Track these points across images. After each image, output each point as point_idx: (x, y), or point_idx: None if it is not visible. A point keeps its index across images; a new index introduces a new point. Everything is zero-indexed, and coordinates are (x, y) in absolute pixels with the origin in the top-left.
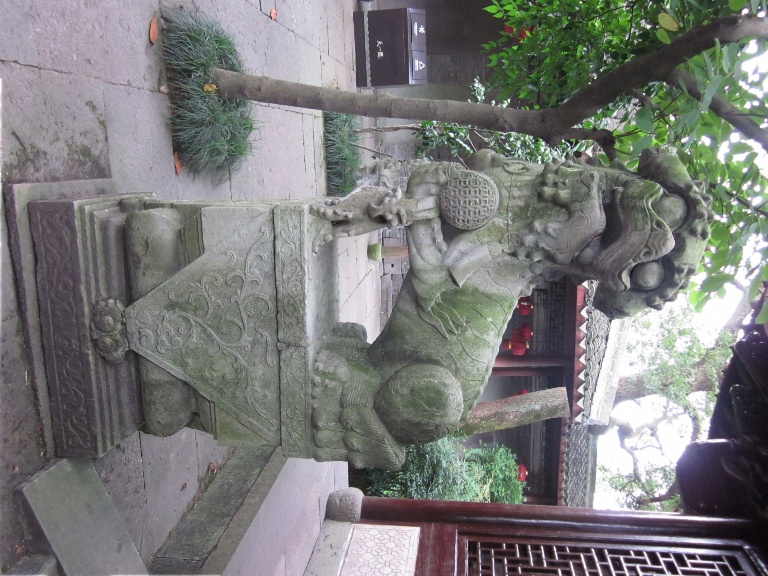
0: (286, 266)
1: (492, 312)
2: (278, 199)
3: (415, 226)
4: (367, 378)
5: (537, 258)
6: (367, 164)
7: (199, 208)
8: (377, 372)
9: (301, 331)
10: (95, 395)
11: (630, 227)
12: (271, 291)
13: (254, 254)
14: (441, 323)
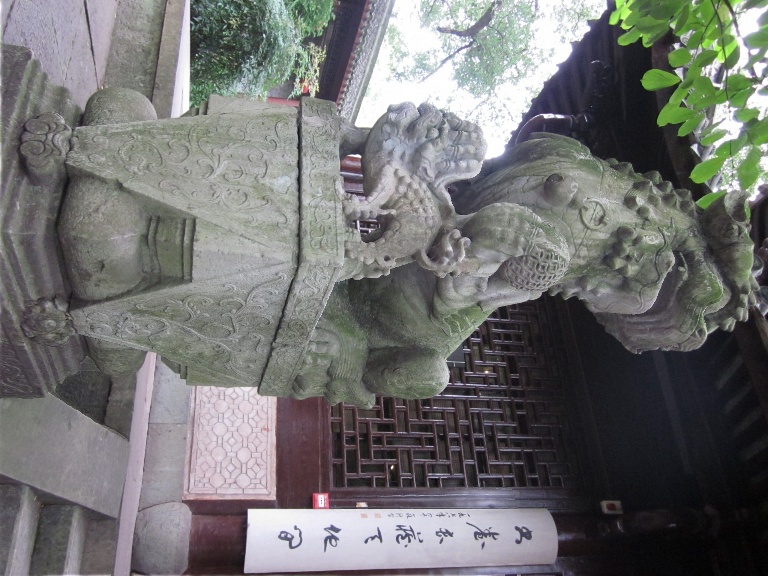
0: (302, 302)
1: None
2: (256, 118)
3: None
4: (355, 345)
5: None
6: (402, 122)
7: (173, 211)
8: (364, 333)
9: (304, 339)
10: (35, 366)
11: (674, 321)
12: (276, 313)
13: (262, 290)
14: (450, 328)
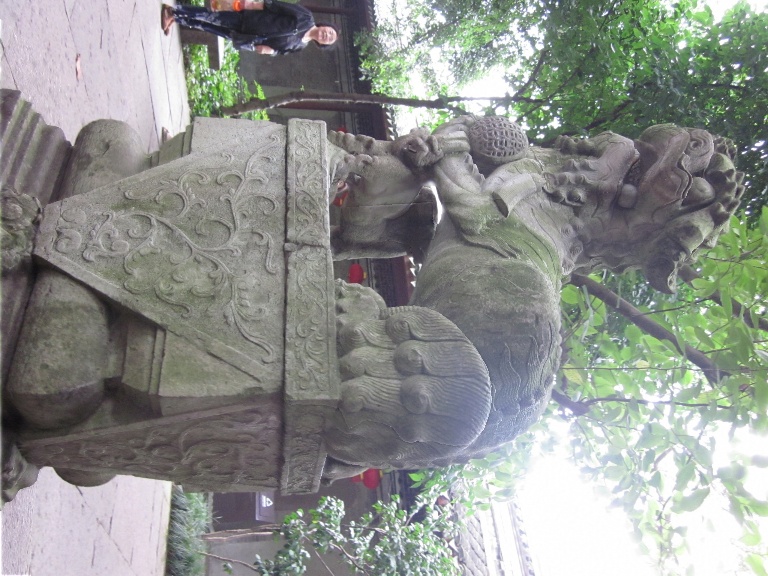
0: (302, 166)
1: (545, 258)
2: None
3: (446, 159)
4: None
5: (580, 194)
6: None
7: None
8: None
9: (321, 230)
10: None
11: (666, 141)
12: (279, 191)
13: (259, 156)
14: (497, 243)
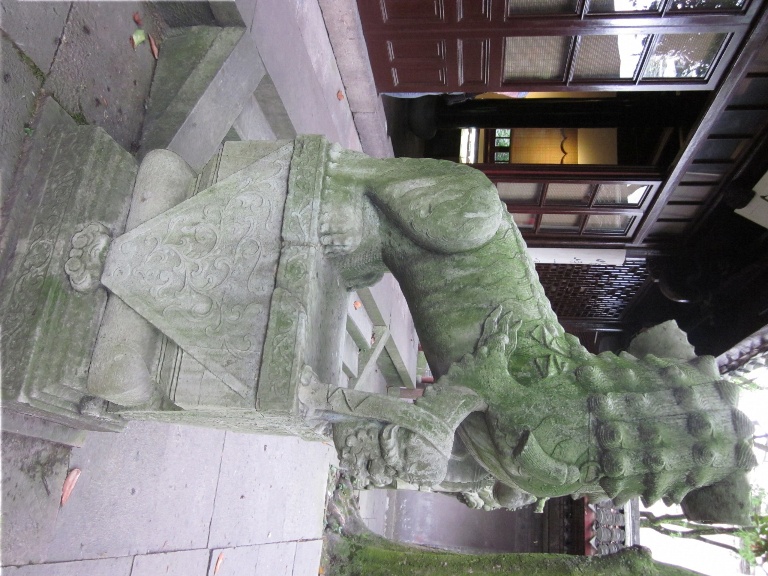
0: None
1: None
2: None
3: None
4: None
5: None
6: None
7: None
8: None
9: None
10: None
11: None
12: None
13: None
14: None
